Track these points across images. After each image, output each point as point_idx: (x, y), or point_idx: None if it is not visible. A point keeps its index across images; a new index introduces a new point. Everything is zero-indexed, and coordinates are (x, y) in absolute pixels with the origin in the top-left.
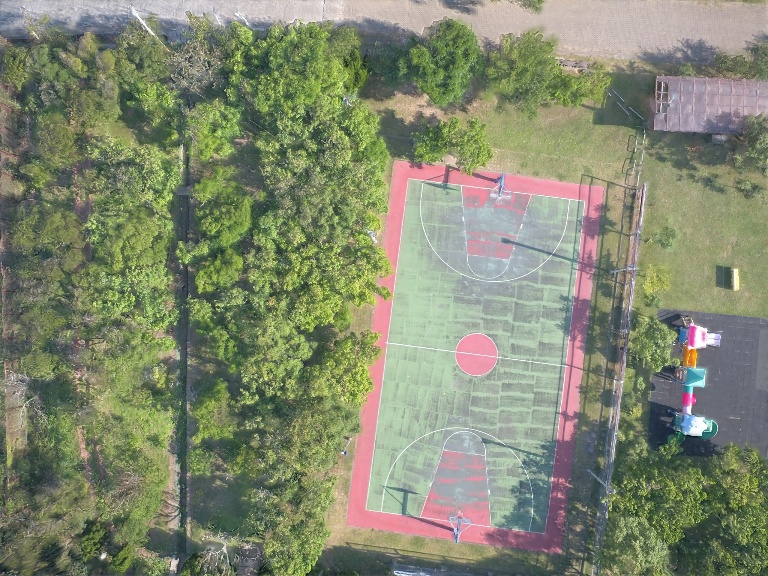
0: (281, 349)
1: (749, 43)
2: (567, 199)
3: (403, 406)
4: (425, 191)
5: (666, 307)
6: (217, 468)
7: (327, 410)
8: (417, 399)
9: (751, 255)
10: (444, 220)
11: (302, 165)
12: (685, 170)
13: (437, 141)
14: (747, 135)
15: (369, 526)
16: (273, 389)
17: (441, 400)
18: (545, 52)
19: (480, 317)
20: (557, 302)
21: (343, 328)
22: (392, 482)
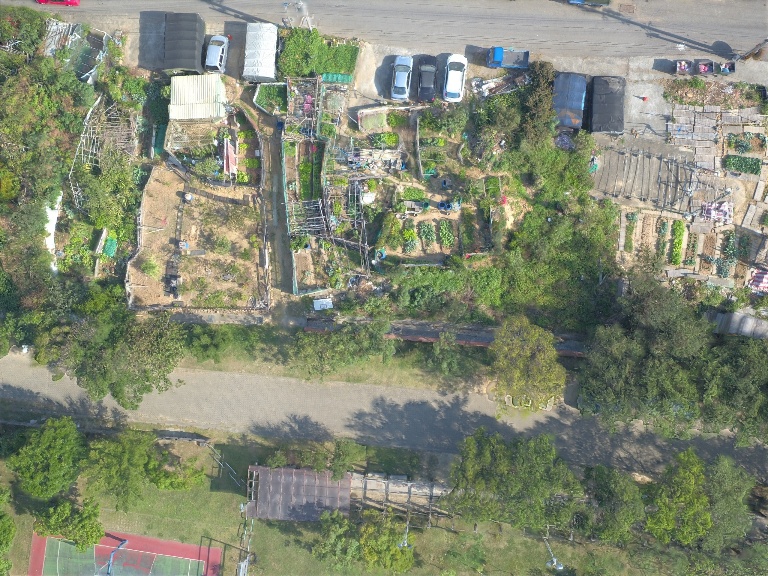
0: None
1: (351, 420)
2: (188, 559)
3: None
4: (62, 549)
5: None
6: None
7: None
8: None
9: None
10: (78, 575)
11: None
12: (293, 536)
13: None
14: None
15: None
16: None
17: None
18: (133, 457)
19: None
20: None
21: None
22: None
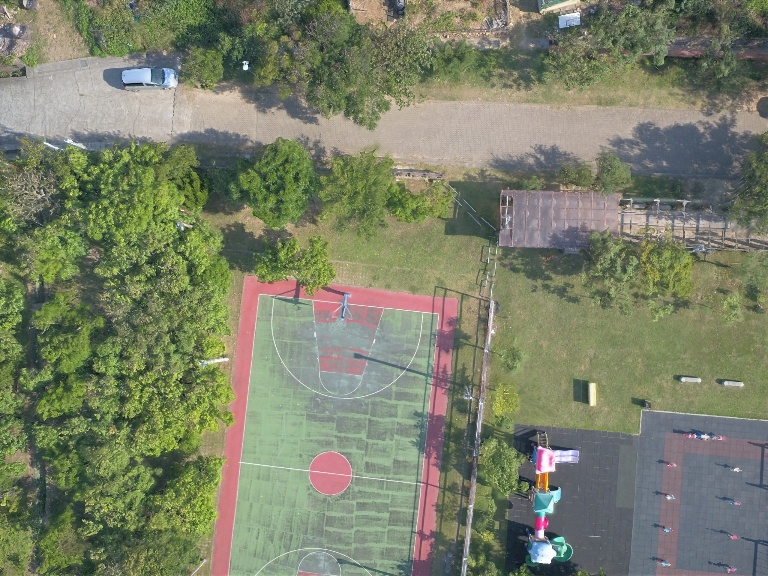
0: (119, 482)
1: (604, 148)
2: (421, 312)
3: (257, 526)
4: (276, 307)
5: (523, 422)
6: None
7: (165, 543)
8: (271, 519)
9: (610, 368)
10: (296, 336)
11: (141, 291)
12: (540, 280)
13: (277, 263)
14: (592, 252)
15: None
16: (114, 520)
17: (295, 520)
18: (379, 173)
19: (333, 435)
20: (411, 418)
21: (191, 452)
22: None
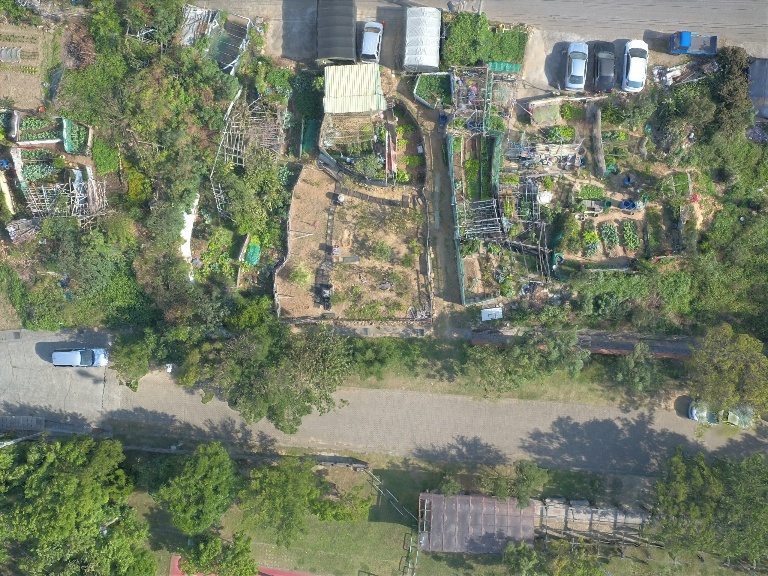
0: None
1: (525, 441)
2: None
3: None
4: None
5: None
6: None
7: None
8: None
9: None
10: None
11: None
12: (461, 569)
13: (199, 561)
14: None
15: None
16: None
17: None
18: (297, 486)
19: None
20: None
21: None
22: None
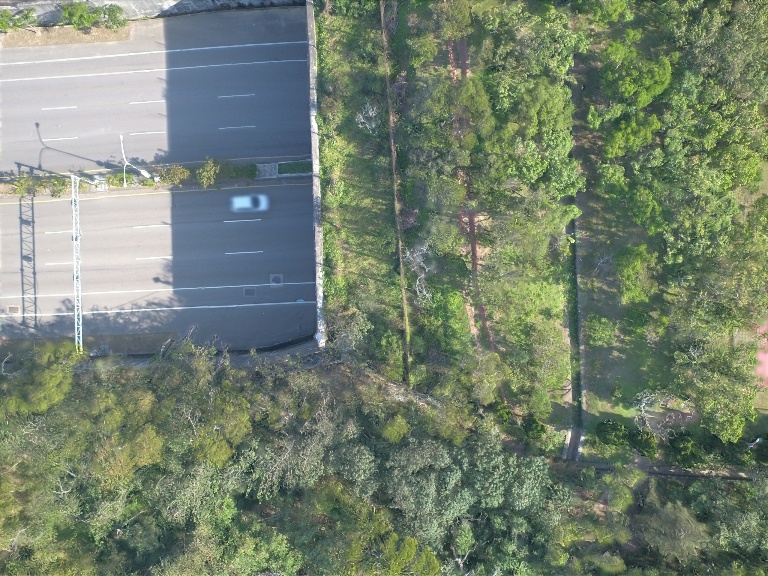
0: (716, 205)
1: None
2: None
3: None
4: None
5: None
6: None
7: (766, 264)
8: None
9: None
10: None
11: (719, 24)
12: None
13: None
14: None
15: None
16: (702, 247)
17: None
18: None
19: None
20: None
21: (754, 190)
22: None
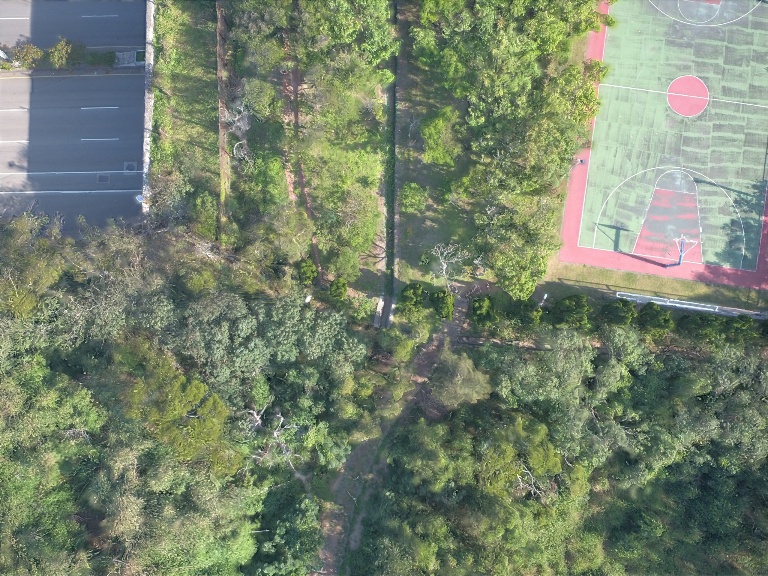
0: (514, 65)
1: None
2: None
3: (615, 145)
4: None
5: None
6: (427, 208)
7: None
8: (629, 138)
9: None
10: None
11: None
12: None
13: None
14: None
15: (581, 262)
16: (502, 108)
17: (653, 140)
18: None
19: (691, 60)
20: (767, 46)
21: (562, 61)
22: (604, 219)
